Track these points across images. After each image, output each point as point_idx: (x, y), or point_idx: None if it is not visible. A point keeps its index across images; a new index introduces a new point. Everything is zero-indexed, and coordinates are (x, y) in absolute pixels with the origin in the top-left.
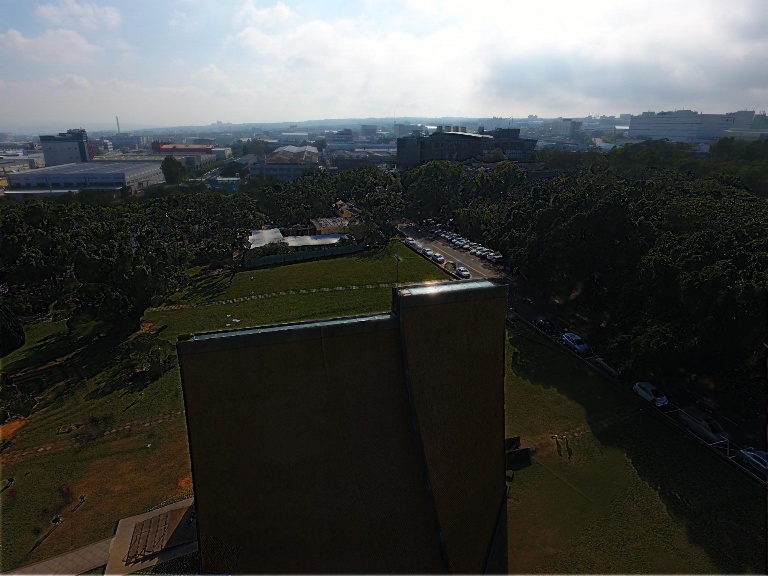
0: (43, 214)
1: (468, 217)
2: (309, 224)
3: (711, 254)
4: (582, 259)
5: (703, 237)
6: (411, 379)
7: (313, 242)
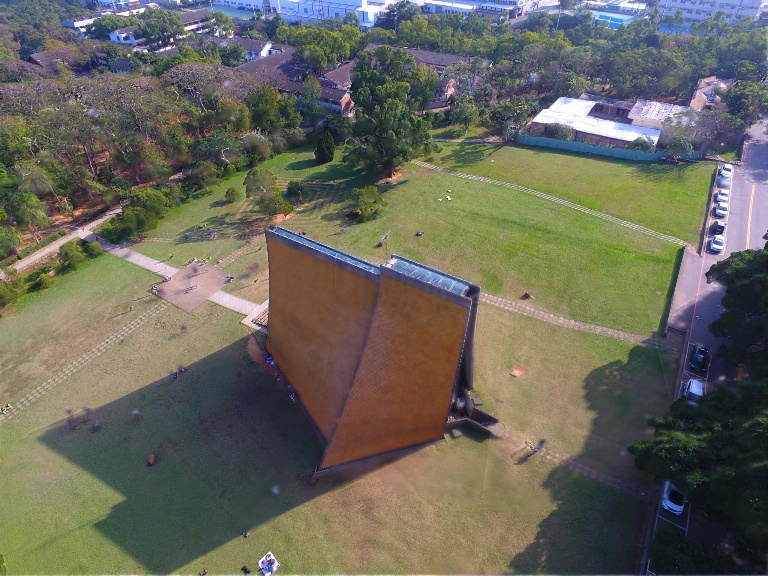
0: (386, 55)
1: None
2: None
3: None
4: None
5: None
6: (372, 323)
7: (609, 132)
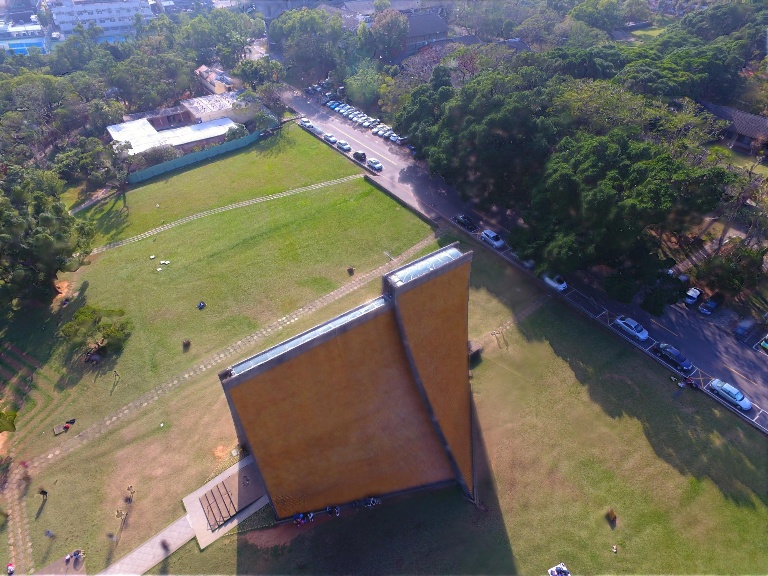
0: None
1: (361, 88)
2: (178, 105)
3: (603, 166)
4: (495, 163)
5: (596, 148)
6: (410, 346)
7: (197, 136)
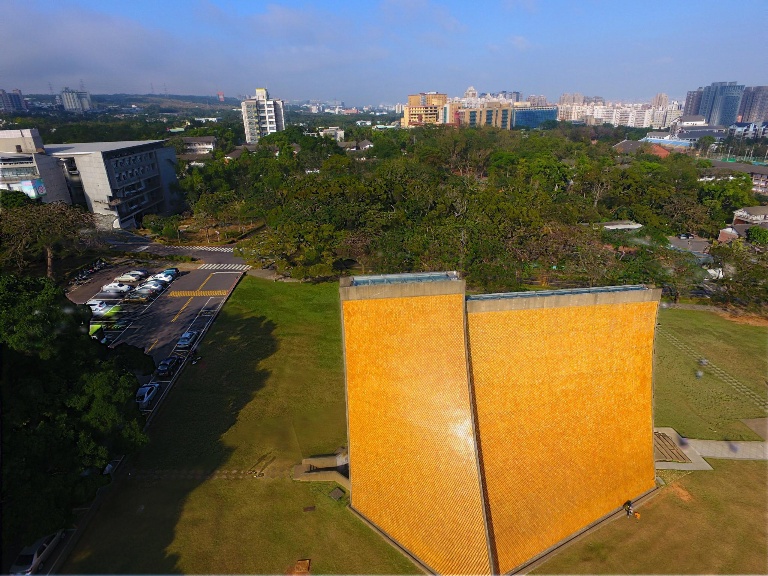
0: None
1: None
2: None
3: None
4: None
5: None
6: None
7: None
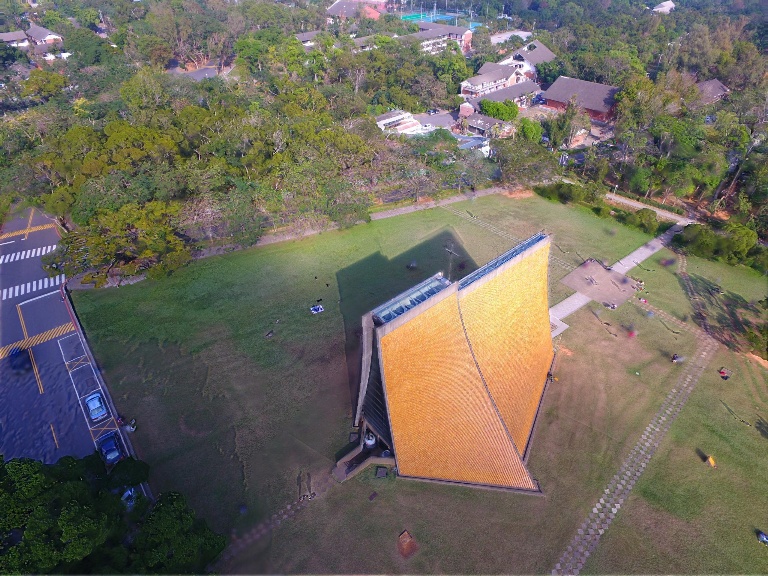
0: None
1: None
2: None
3: None
4: None
5: None
6: None
7: None
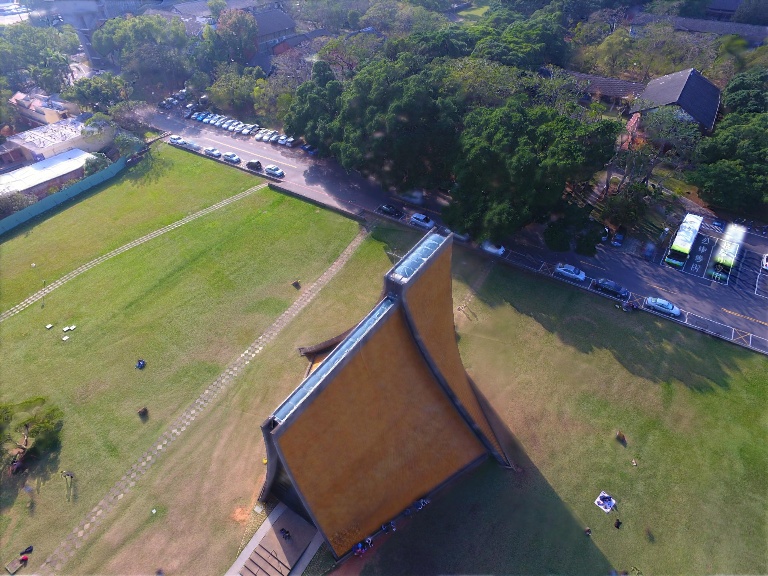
0: None
1: (229, 94)
2: (1, 143)
3: (513, 134)
4: (410, 148)
5: (503, 118)
6: (422, 340)
7: (46, 175)
